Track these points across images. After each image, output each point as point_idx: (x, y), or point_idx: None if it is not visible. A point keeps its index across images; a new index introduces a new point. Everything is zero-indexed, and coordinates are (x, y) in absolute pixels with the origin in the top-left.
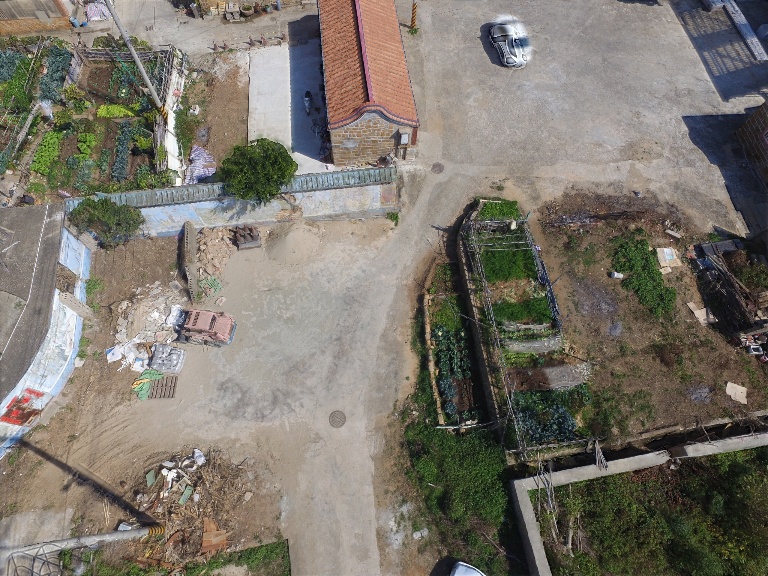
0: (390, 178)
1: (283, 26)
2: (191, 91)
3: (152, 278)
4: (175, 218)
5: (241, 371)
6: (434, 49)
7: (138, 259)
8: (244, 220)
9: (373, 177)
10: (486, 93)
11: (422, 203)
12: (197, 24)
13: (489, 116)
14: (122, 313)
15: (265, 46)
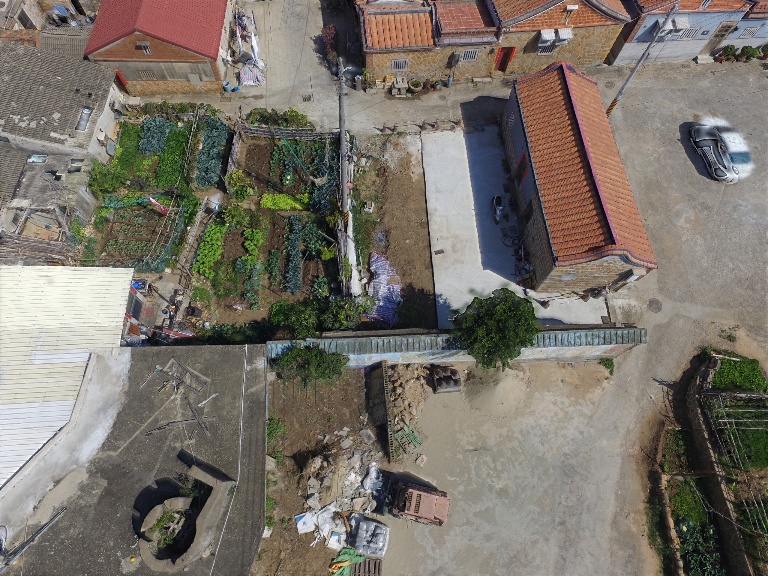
0: (639, 340)
1: (455, 107)
2: (361, 182)
3: (339, 422)
4: (374, 358)
5: (454, 558)
6: (631, 151)
7: (321, 396)
8: (445, 360)
9: (620, 338)
10: (698, 212)
11: (640, 349)
12: (359, 97)
13: (706, 242)
14: (314, 472)
15: (437, 131)
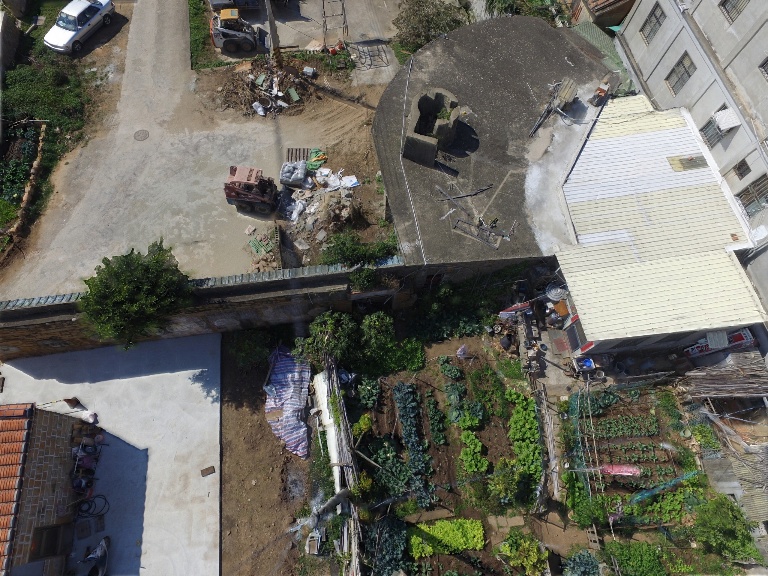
0: None
1: None
2: None
3: None
4: None
5: (228, 169)
6: None
7: None
8: None
9: None
10: None
11: None
12: None
13: None
14: None
15: None
